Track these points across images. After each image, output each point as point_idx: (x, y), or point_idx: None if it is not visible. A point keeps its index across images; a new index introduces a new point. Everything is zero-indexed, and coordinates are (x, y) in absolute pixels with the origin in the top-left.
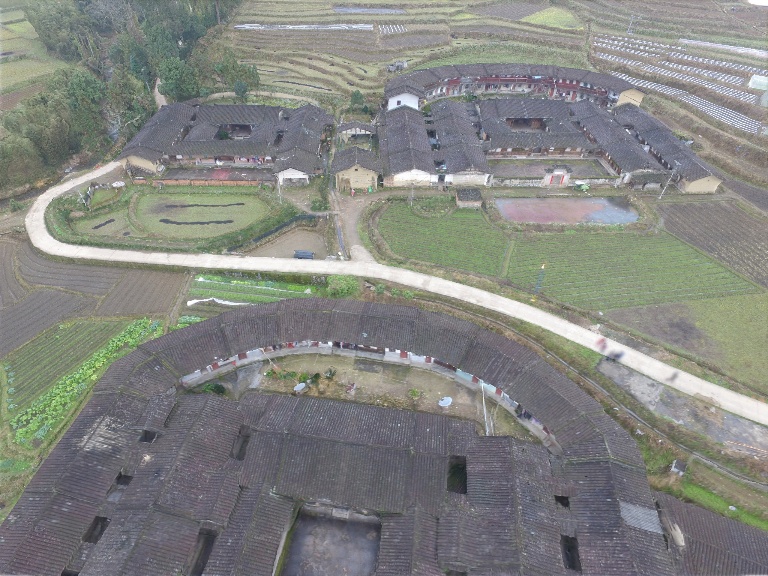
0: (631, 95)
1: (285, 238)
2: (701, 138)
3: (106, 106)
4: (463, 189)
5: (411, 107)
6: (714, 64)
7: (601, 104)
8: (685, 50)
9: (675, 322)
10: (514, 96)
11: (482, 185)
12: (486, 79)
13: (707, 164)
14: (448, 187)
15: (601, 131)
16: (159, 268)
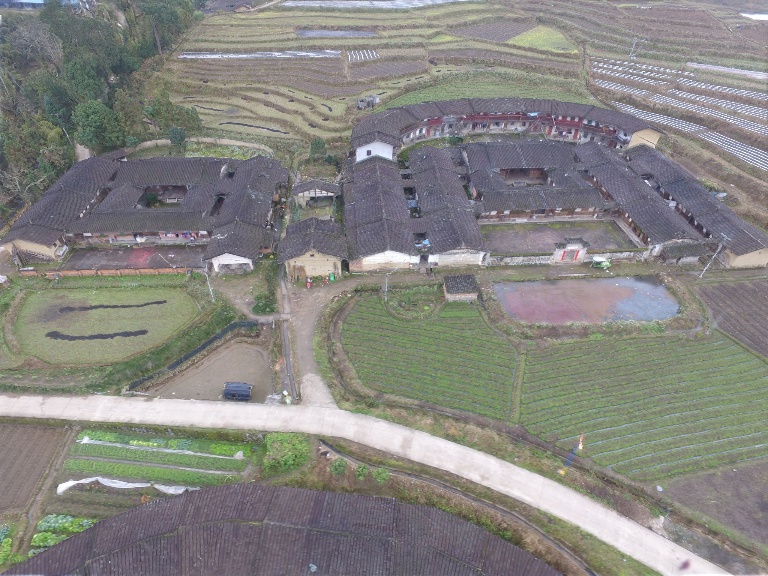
0: (645, 135)
1: (216, 357)
2: (734, 188)
3: (7, 162)
4: (452, 276)
5: (384, 157)
6: (732, 93)
7: (609, 144)
8: (696, 76)
9: (766, 500)
10: (506, 136)
11: (476, 265)
12: (473, 117)
13: (747, 223)
14: (433, 269)
15: (616, 184)
16: (28, 421)
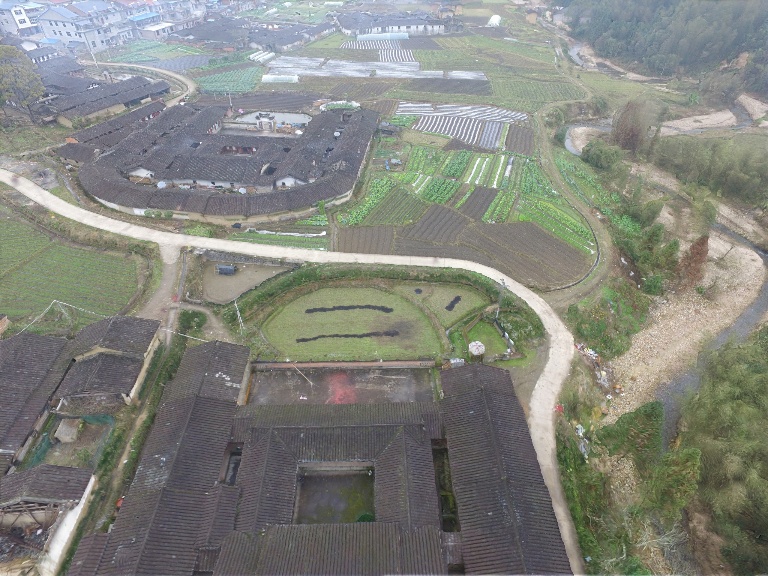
0: None
1: None
2: None
3: None
4: None
5: None
6: None
7: None
8: None
9: None
10: None
11: None
12: None
13: None
14: None
15: None
16: None
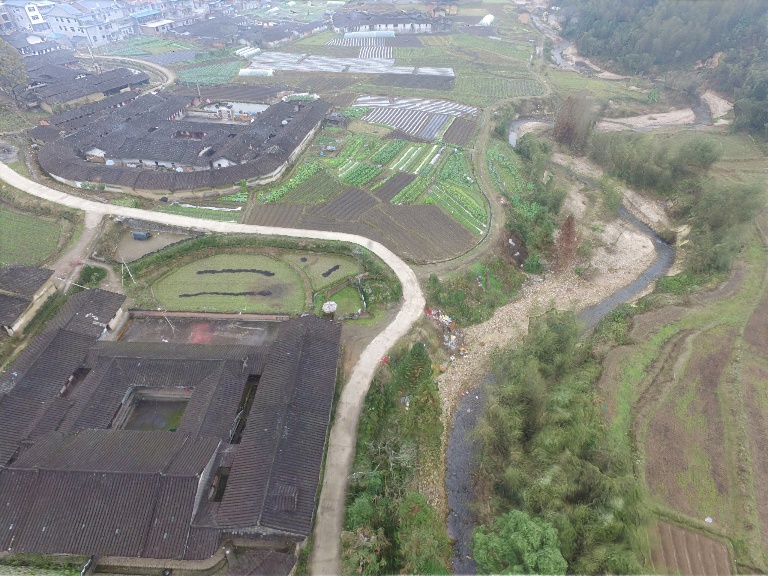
0: None
1: None
2: None
3: None
4: None
5: None
6: None
7: None
8: None
9: None
10: None
11: None
12: None
13: None
14: None
15: None
16: None
